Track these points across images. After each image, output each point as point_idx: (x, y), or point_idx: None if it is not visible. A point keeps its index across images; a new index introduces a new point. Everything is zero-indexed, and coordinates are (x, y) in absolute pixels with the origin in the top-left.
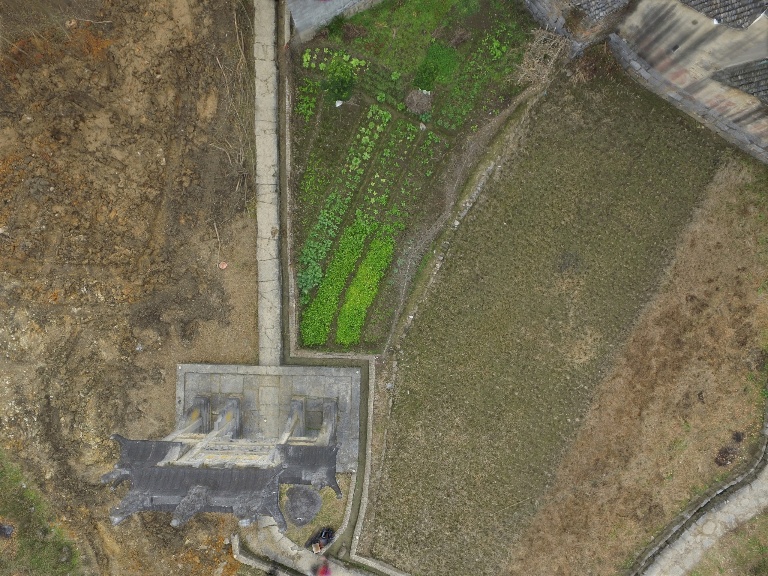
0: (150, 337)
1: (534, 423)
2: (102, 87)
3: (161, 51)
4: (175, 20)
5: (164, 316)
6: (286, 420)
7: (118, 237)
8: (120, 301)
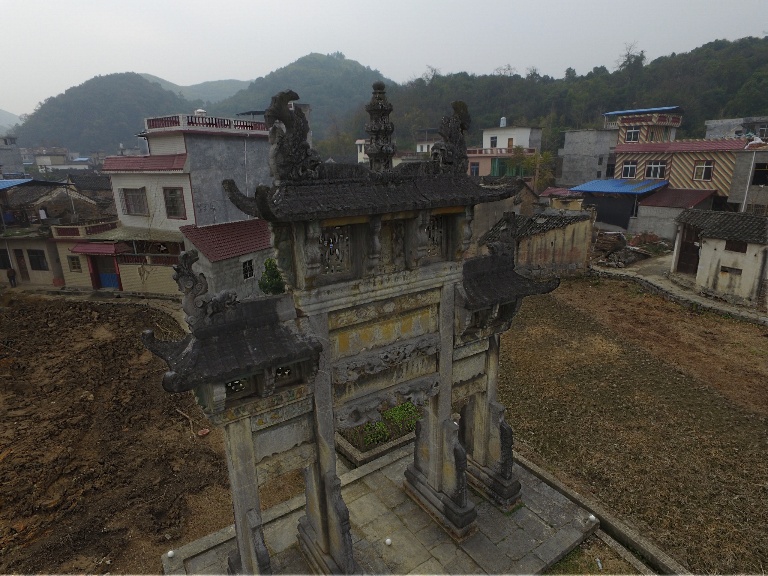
0: (80, 568)
1: (664, 394)
2: (3, 377)
3: (82, 348)
4: (95, 338)
5: (110, 525)
6: (421, 522)
7: (11, 472)
8: (5, 545)
